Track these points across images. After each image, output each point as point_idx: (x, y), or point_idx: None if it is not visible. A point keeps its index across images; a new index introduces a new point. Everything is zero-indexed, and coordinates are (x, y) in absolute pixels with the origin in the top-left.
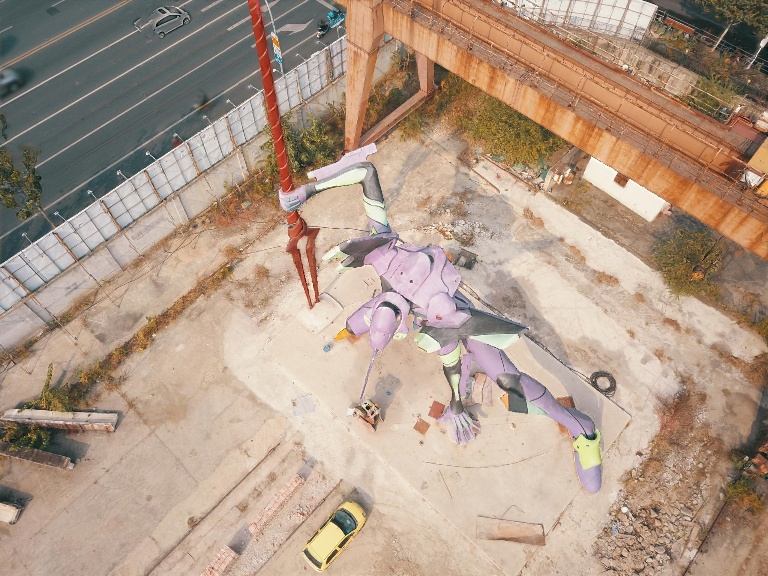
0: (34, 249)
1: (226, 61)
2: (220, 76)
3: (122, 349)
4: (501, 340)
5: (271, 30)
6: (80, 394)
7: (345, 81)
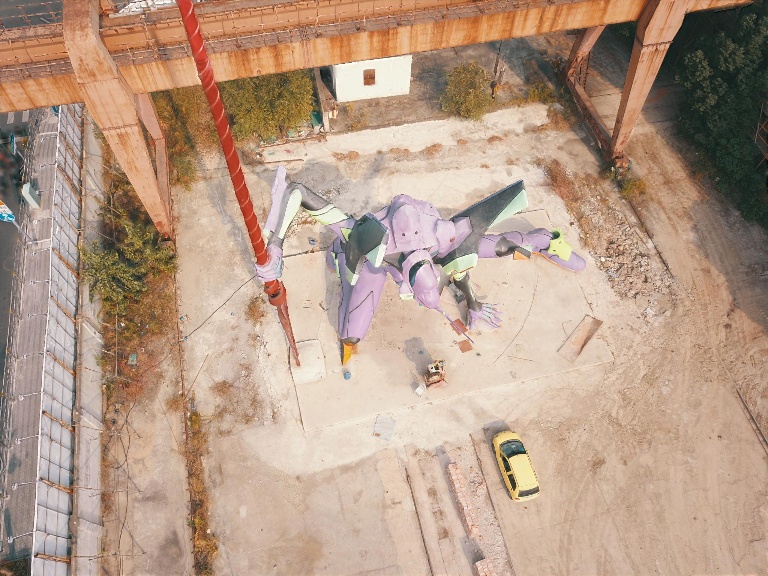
0: None
1: None
2: None
3: (204, 571)
4: (520, 202)
5: None
6: None
7: (88, 185)
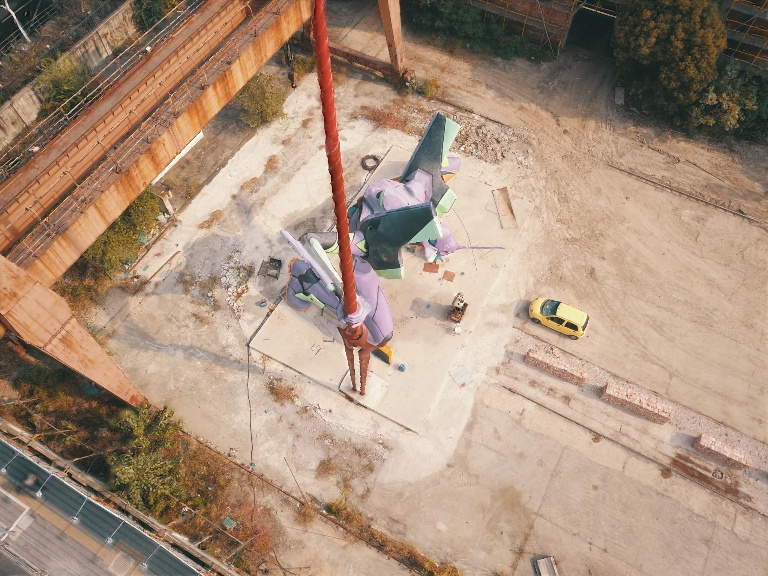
0: None
1: None
2: None
3: None
4: (453, 128)
5: None
6: None
7: None
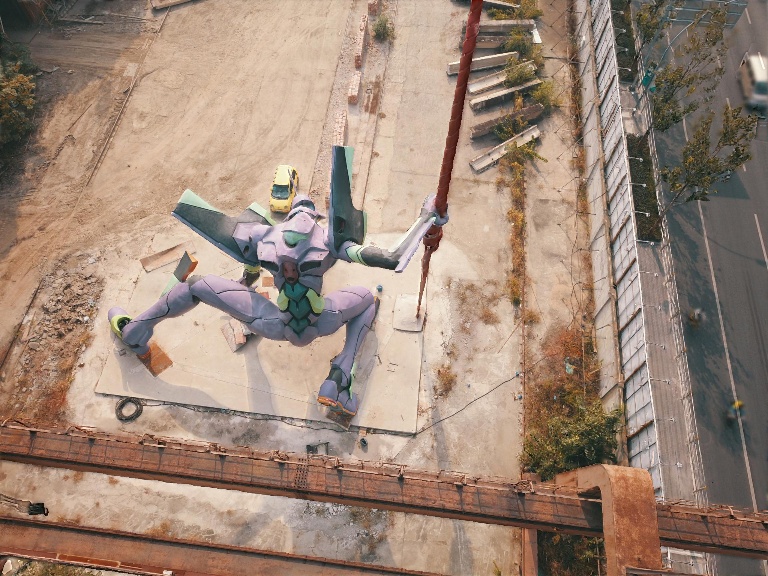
0: (622, 158)
1: None
2: None
3: (518, 197)
4: (190, 195)
5: None
6: None
7: None
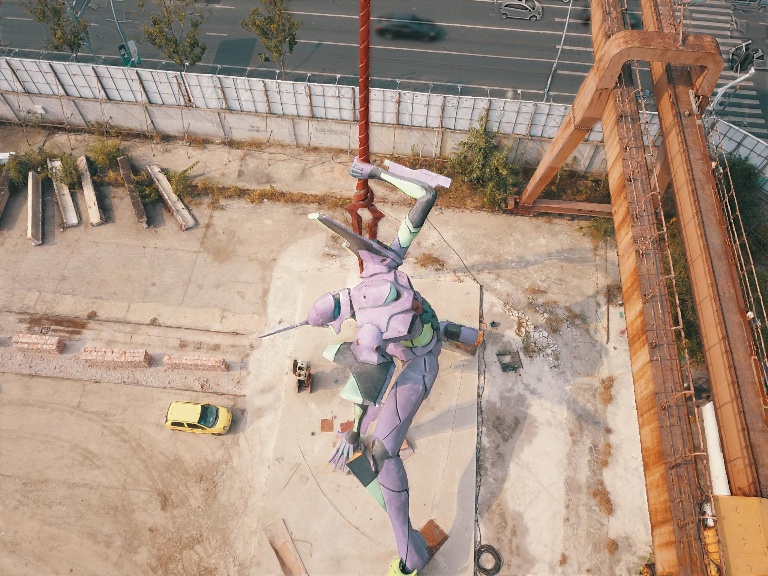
0: (244, 82)
1: (526, 67)
2: (508, 75)
3: (238, 189)
4: (349, 390)
5: (588, 70)
6: (192, 192)
7: (583, 148)
